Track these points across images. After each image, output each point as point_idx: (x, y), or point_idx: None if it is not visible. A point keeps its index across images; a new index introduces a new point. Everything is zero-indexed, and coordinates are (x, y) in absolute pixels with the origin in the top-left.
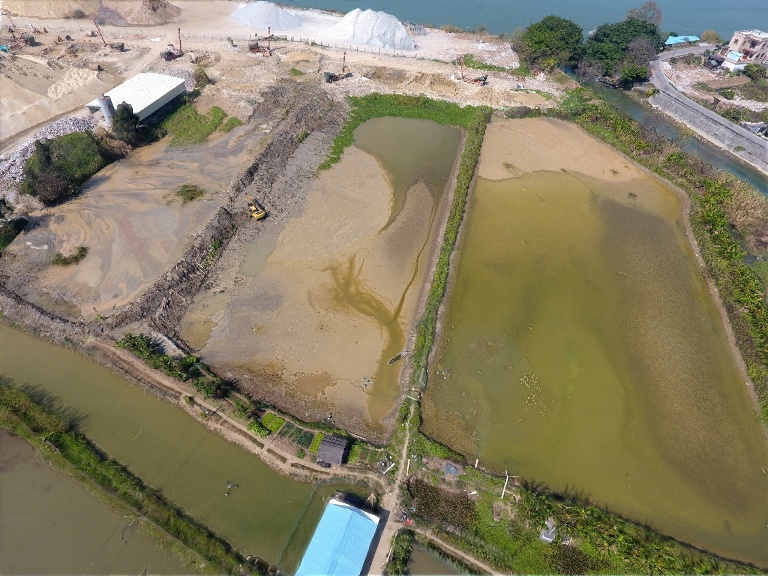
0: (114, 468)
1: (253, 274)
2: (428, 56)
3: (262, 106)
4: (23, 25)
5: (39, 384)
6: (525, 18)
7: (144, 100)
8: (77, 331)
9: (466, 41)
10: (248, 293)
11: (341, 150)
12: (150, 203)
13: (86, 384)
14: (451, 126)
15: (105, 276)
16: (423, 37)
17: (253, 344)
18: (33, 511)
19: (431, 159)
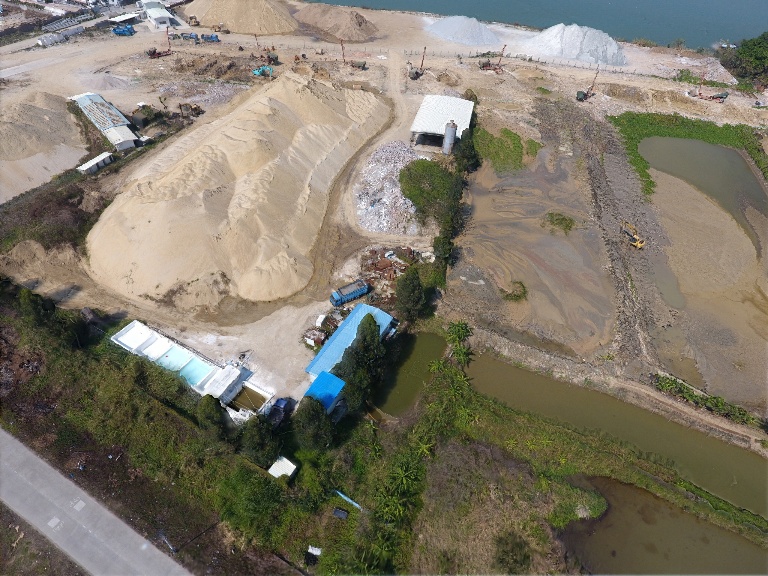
0: (760, 518)
1: (682, 307)
2: (643, 72)
3: (542, 127)
4: (245, 42)
5: (599, 429)
6: (701, 30)
7: (460, 124)
8: (597, 372)
9: (665, 55)
10: (696, 327)
11: (647, 173)
12: (535, 233)
13: (636, 427)
14: (723, 146)
15: (564, 312)
16: (621, 51)
17: (749, 382)
18: (709, 565)
19: (736, 181)
